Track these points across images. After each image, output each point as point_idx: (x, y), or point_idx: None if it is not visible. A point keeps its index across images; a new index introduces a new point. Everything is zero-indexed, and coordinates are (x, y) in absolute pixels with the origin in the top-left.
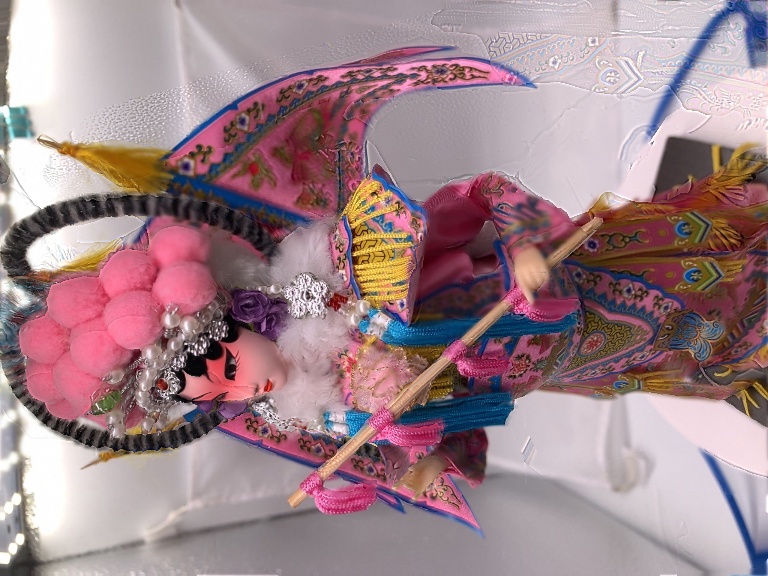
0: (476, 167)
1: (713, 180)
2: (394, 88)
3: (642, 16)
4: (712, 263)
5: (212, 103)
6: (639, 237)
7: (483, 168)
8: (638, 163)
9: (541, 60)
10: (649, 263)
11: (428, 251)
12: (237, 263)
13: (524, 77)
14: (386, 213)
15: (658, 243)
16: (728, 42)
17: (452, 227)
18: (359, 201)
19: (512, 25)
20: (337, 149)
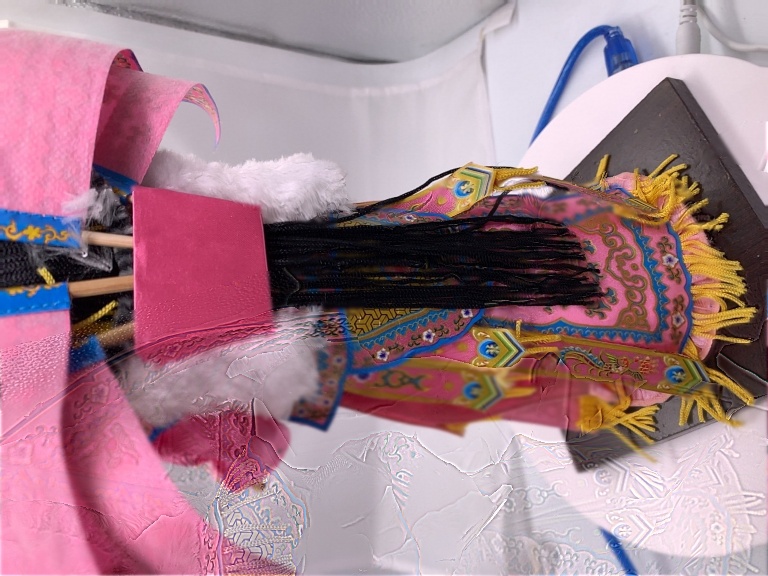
0: (390, 397)
1: (622, 412)
2: (281, 342)
3: (513, 286)
4: (638, 516)
5: (110, 344)
6: (557, 490)
7: (397, 397)
8: (547, 392)
9: (414, 335)
10: (572, 520)
11: (318, 536)
12: (74, 575)
13: (397, 353)
14: (262, 498)
15: (578, 496)
16: (604, 307)
17: (347, 500)
18: (232, 483)
19: (378, 301)
20: (218, 411)
